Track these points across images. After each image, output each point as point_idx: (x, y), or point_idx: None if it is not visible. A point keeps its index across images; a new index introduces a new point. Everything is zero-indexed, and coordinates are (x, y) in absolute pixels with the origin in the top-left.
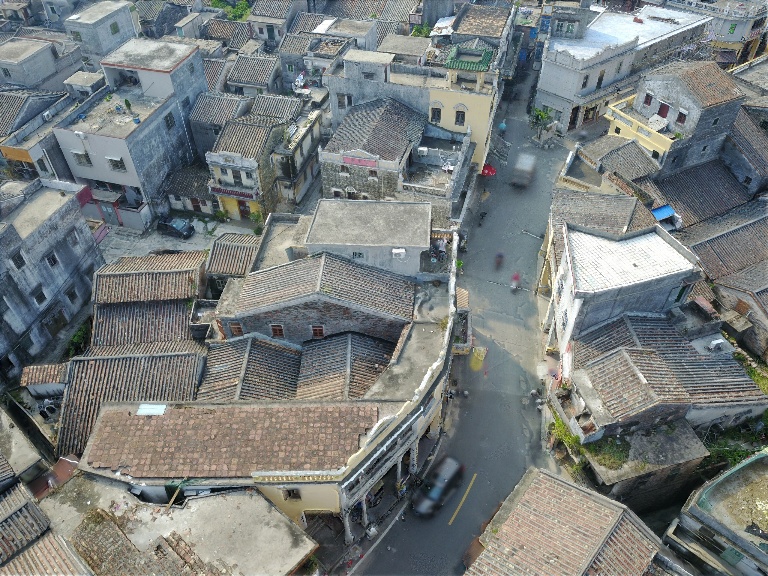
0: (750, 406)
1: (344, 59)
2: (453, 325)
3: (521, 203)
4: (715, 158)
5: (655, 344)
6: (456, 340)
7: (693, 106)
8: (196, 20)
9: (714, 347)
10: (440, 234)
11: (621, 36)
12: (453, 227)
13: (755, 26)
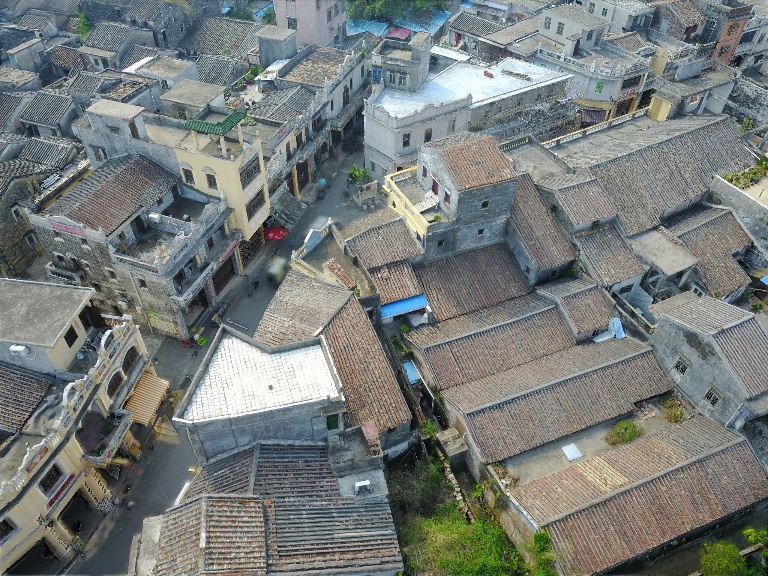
0: (362, 573)
1: (86, 110)
2: (63, 440)
3: None
4: (500, 241)
5: (279, 484)
6: (96, 450)
7: (453, 187)
8: (35, 47)
9: (360, 489)
10: (114, 322)
11: (461, 91)
12: (125, 316)
13: (628, 85)
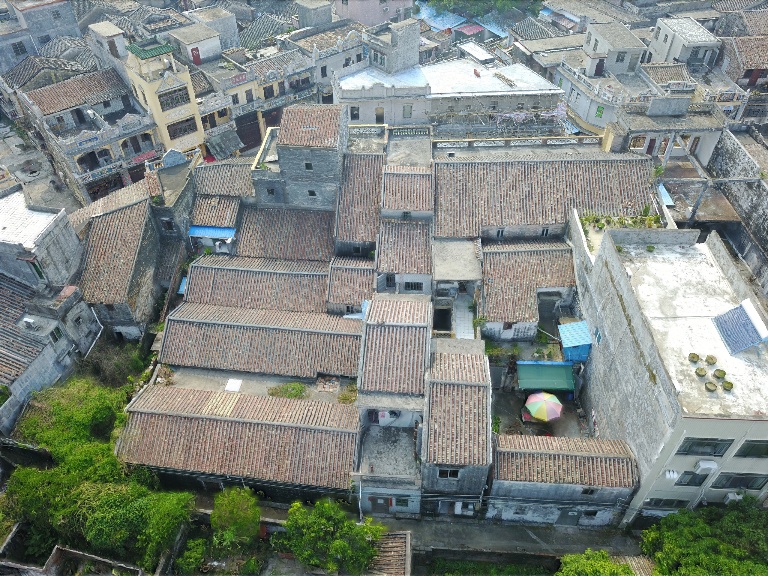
0: None
1: None
2: None
3: None
4: None
5: None
6: None
7: None
8: None
9: (27, 324)
10: None
11: (434, 82)
12: (2, 166)
13: None
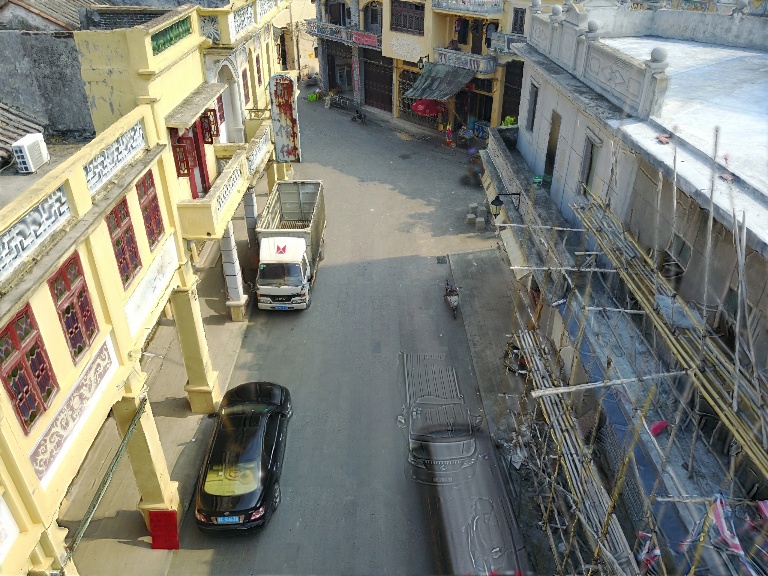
0: None
1: None
2: None
3: (355, 148)
4: None
5: None
6: None
7: None
8: None
9: None
10: None
11: None
12: None
13: None
